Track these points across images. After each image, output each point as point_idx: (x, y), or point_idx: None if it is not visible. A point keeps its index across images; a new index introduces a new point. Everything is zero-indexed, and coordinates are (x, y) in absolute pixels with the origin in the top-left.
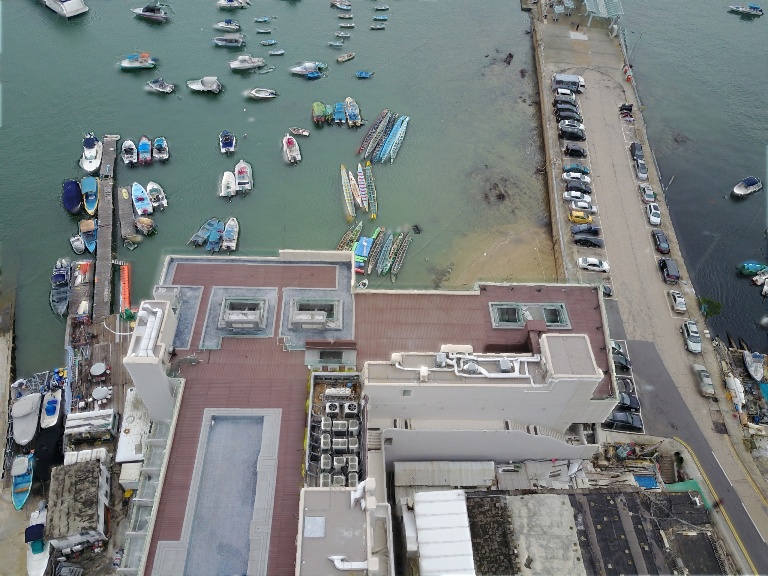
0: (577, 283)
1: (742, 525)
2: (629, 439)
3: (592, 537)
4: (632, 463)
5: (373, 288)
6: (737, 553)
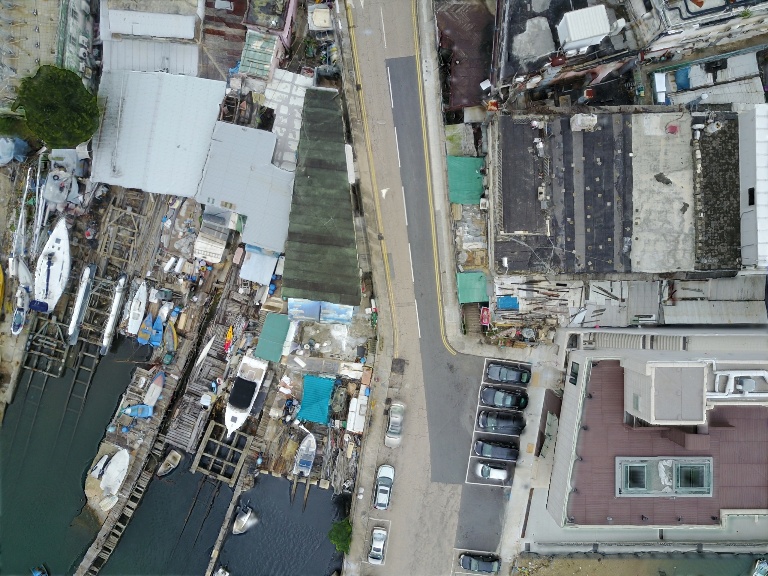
0: (500, 575)
1: (425, 259)
2: (506, 352)
3: (619, 230)
4: (516, 323)
5: (745, 573)
6: (443, 232)
